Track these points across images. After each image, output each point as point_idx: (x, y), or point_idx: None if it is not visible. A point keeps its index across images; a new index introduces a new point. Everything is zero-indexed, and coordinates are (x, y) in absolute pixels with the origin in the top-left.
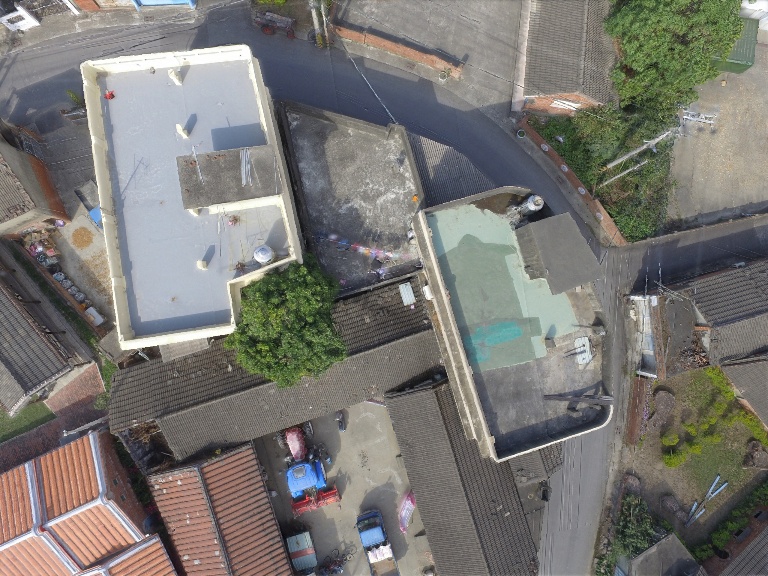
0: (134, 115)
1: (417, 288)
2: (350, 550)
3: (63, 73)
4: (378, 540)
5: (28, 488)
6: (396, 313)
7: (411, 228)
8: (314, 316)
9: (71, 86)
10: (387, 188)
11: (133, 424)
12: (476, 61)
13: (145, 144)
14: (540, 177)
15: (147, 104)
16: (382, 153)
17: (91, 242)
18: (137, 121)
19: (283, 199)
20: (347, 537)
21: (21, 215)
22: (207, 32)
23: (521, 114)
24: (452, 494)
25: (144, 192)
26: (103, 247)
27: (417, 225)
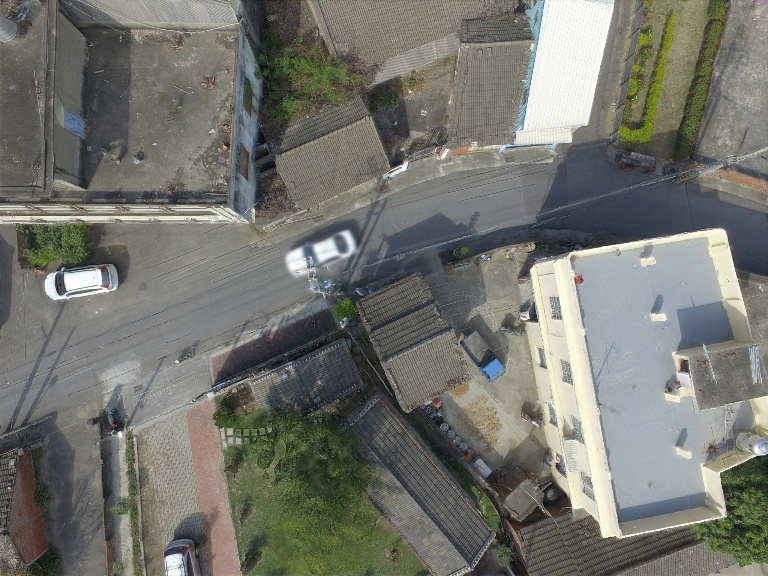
0: (603, 299)
1: None
2: None
3: (430, 218)
4: None
5: None
6: None
7: None
8: None
9: (438, 231)
10: None
11: None
12: None
13: (615, 328)
14: None
15: (615, 287)
16: None
17: (468, 390)
18: (607, 305)
19: None
20: None
21: None
22: (566, 171)
23: None
24: None
25: (617, 377)
26: (479, 394)
27: None
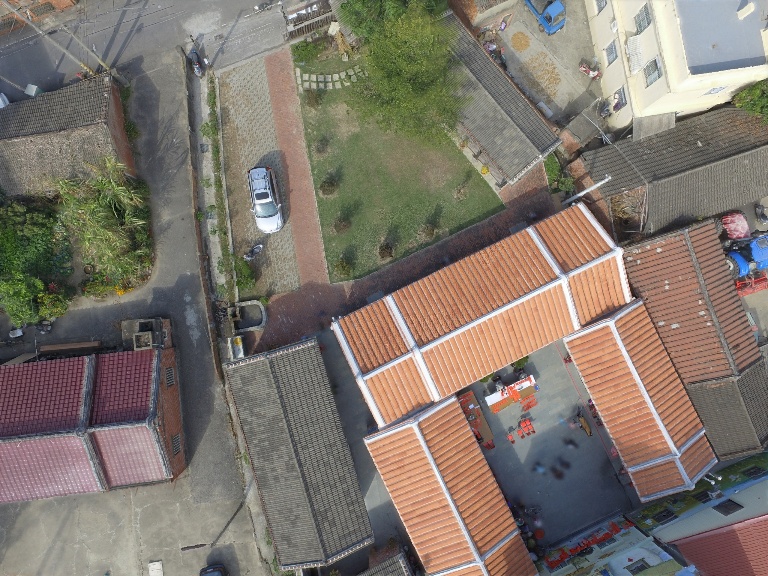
0: None
1: None
2: None
3: None
4: None
5: (537, 247)
6: None
7: None
8: None
9: None
10: None
11: (623, 191)
12: None
13: None
14: None
15: None
16: None
17: (528, 46)
18: None
19: None
20: None
21: None
22: None
23: None
24: None
25: None
26: (539, 50)
27: None
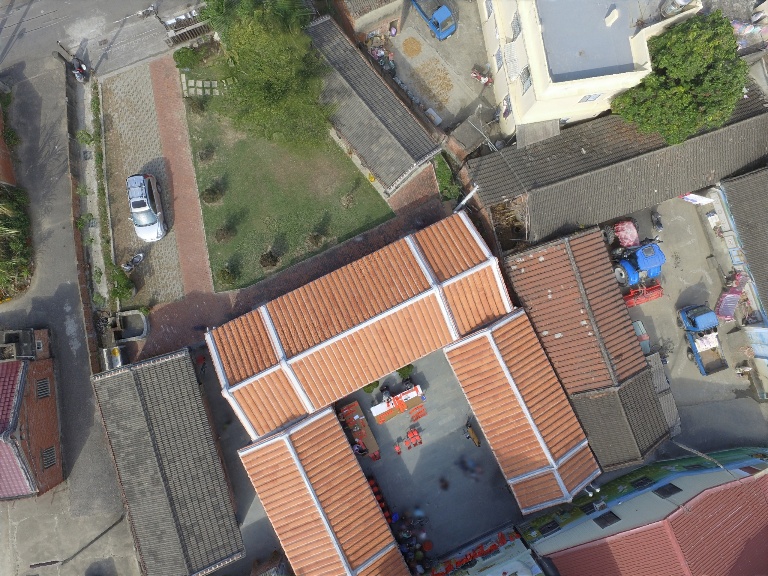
0: None
1: None
2: (668, 346)
3: None
4: (713, 324)
5: (414, 257)
6: None
7: (756, 12)
8: None
9: None
10: None
11: (503, 199)
12: None
13: None
14: None
15: None
16: None
17: (420, 51)
18: None
19: None
20: (664, 334)
21: (396, 1)
22: None
23: None
24: None
25: None
26: (431, 56)
27: None
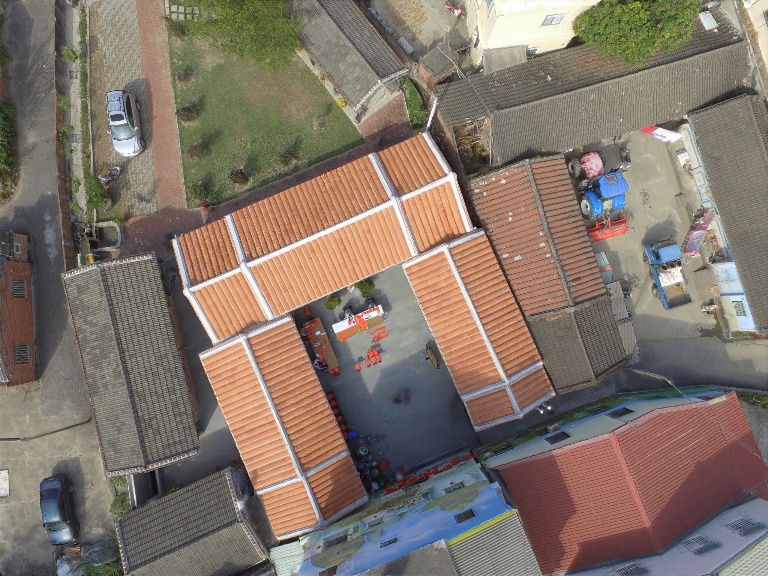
0: None
1: (717, 15)
2: (633, 282)
3: None
4: (676, 256)
5: (376, 172)
6: (700, 36)
7: None
8: None
9: None
10: None
11: (467, 121)
12: None
13: None
14: None
15: None
16: None
17: None
18: None
19: None
20: (630, 269)
21: None
22: None
23: None
24: (763, 199)
25: None
26: None
27: None
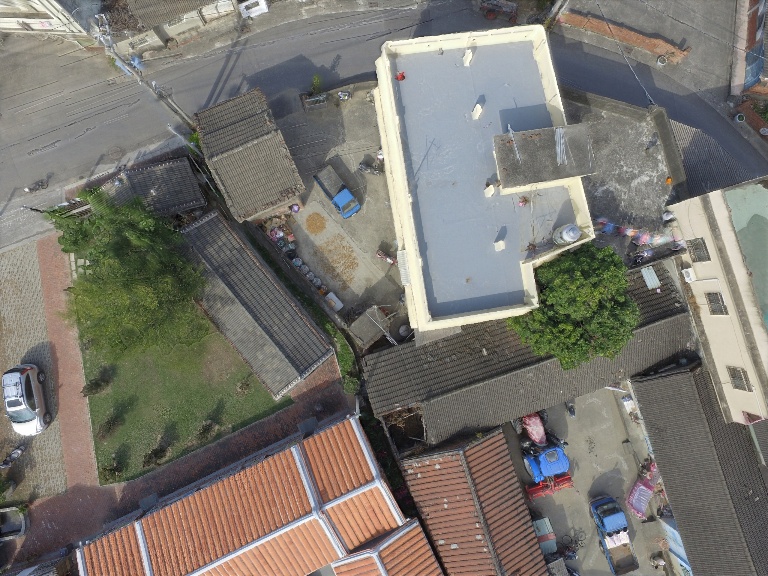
0: (425, 96)
1: (660, 272)
2: (579, 536)
3: (291, 59)
4: (622, 525)
5: (298, 472)
6: (642, 297)
7: (667, 211)
8: (624, 296)
9: (299, 72)
10: (641, 171)
11: (396, 408)
12: (693, 45)
13: (436, 125)
14: (758, 161)
15: (437, 85)
16: (635, 136)
17: (324, 228)
18: (428, 102)
19: (580, 179)
20: (576, 523)
21: None
22: (430, 18)
23: (740, 98)
24: (708, 478)
25: (437, 173)
26: (336, 233)
27: (706, 205)
